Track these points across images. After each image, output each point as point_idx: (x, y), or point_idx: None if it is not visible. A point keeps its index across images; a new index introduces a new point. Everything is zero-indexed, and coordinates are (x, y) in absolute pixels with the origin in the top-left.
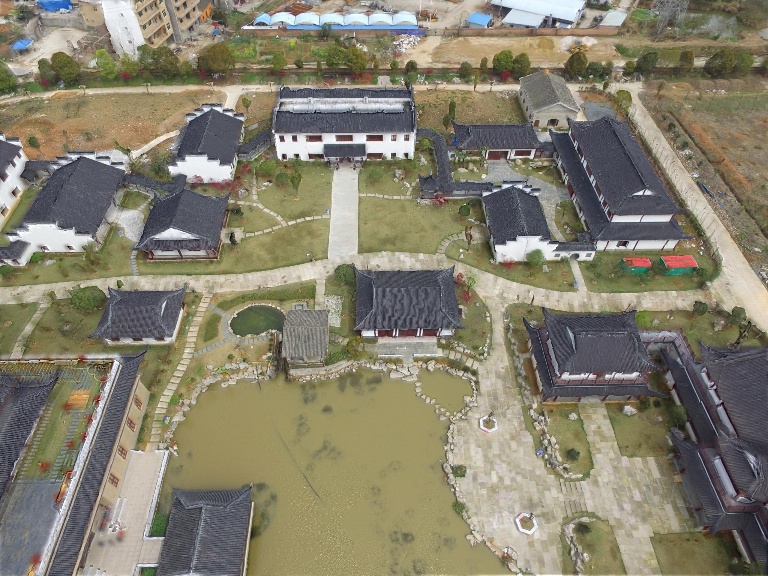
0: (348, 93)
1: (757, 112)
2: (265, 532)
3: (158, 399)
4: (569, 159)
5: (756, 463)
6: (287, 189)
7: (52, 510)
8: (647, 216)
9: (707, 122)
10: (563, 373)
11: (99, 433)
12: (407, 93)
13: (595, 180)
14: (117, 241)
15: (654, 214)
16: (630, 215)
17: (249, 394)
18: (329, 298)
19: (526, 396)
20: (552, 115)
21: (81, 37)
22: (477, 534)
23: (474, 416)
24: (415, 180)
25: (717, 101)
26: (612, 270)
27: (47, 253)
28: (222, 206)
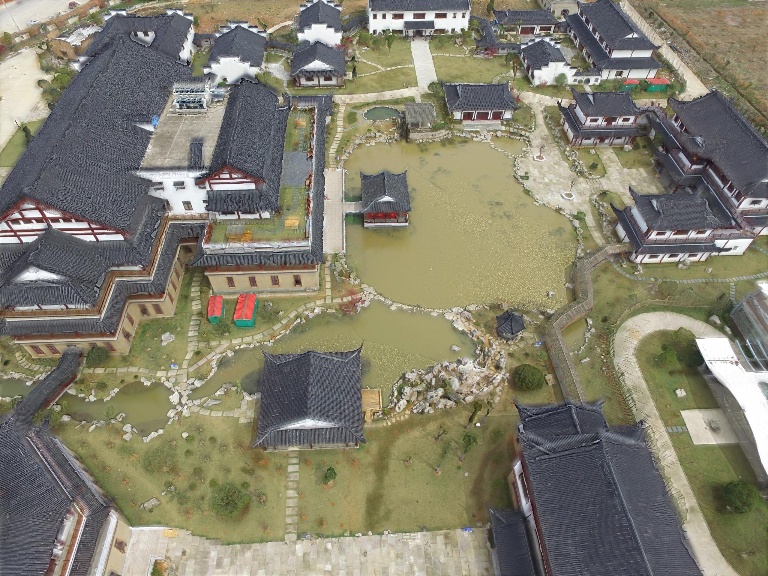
0: None
1: (714, 7)
2: (413, 202)
3: (328, 150)
4: (579, 28)
5: (701, 139)
6: (380, 52)
7: (306, 161)
8: (635, 52)
9: (677, 13)
10: (586, 120)
11: (316, 139)
12: None
13: (599, 34)
14: (271, 79)
15: (640, 49)
16: (624, 50)
17: (380, 156)
18: None
19: (562, 146)
20: (564, 6)
21: None
22: (539, 201)
23: (530, 156)
24: (470, 46)
25: (685, 1)
26: (612, 90)
27: (226, 84)
28: (342, 55)
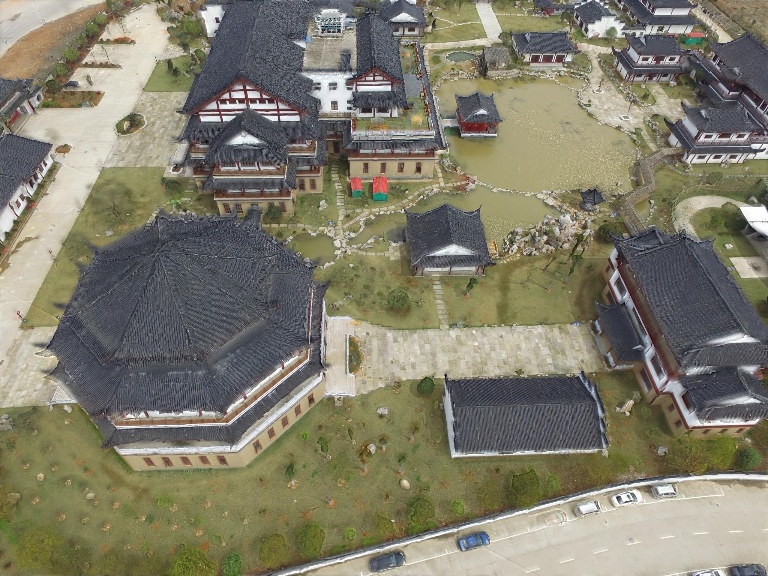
0: None
1: None
2: None
3: None
4: None
5: (738, 69)
6: (450, 11)
7: None
8: (675, 9)
9: None
10: (639, 59)
11: None
12: None
13: None
14: None
15: (679, 7)
16: (666, 8)
17: None
18: None
19: (616, 83)
20: None
21: None
22: (602, 122)
23: (590, 90)
24: (528, 8)
25: None
26: None
27: None
28: None
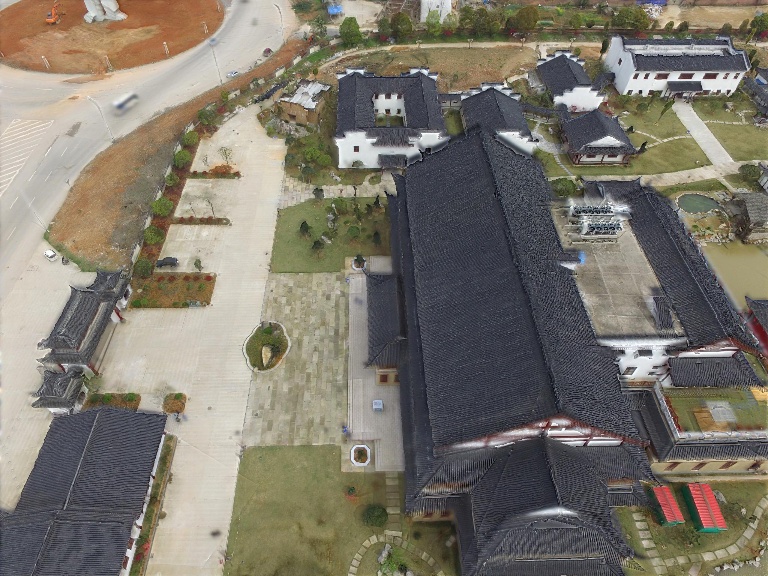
0: (677, 41)
1: None
2: None
3: None
4: None
5: None
6: (643, 117)
7: None
8: None
9: None
10: None
11: None
12: (724, 41)
13: None
14: None
15: None
16: None
17: None
18: (740, 190)
19: None
20: None
21: (370, 6)
22: None
23: None
24: (742, 111)
25: None
26: None
27: None
28: (616, 125)
